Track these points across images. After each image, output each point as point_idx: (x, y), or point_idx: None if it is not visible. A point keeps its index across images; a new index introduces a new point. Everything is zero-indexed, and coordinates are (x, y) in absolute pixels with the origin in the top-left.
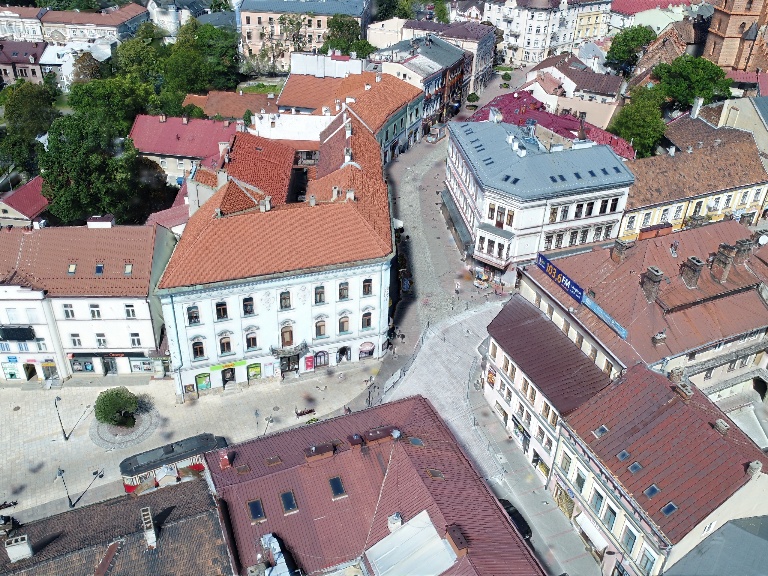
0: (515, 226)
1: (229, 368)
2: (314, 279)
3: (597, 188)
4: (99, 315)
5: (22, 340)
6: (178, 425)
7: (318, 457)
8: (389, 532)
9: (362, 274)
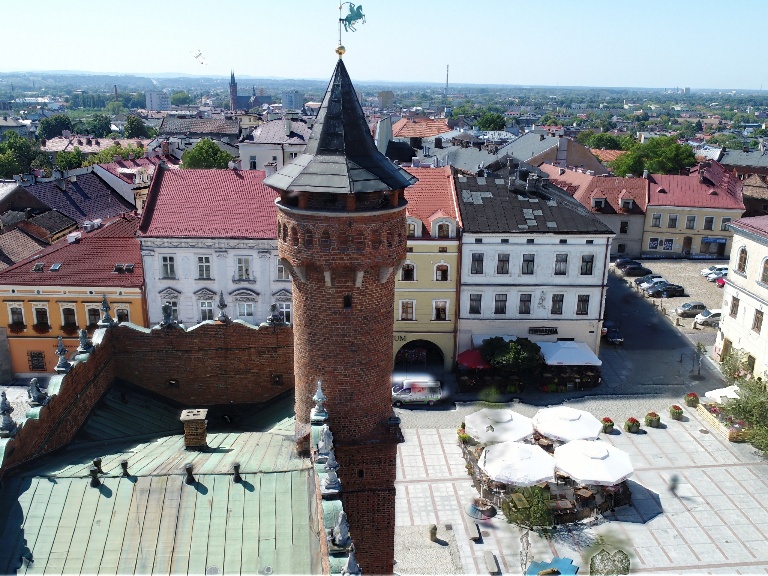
0: None
1: None
2: None
3: None
4: None
5: None
6: None
7: None
8: None
9: None
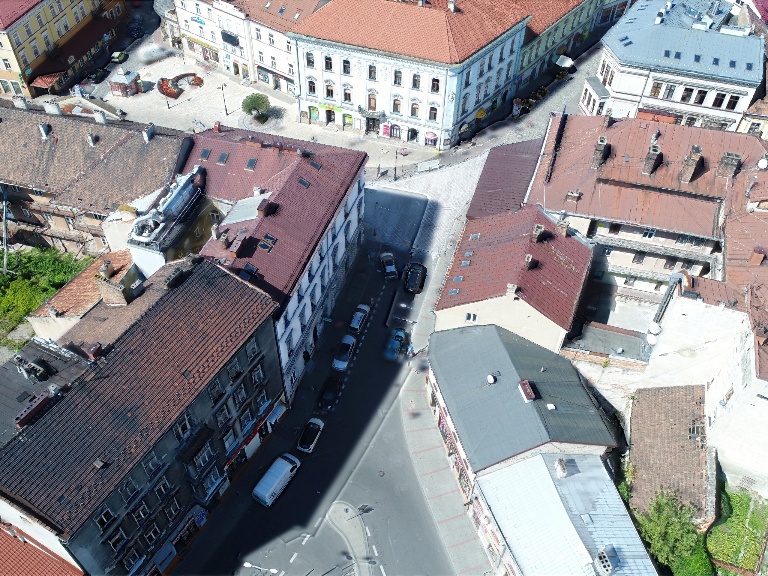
0: (612, 87)
1: (331, 110)
2: (394, 63)
3: (710, 77)
4: (274, 43)
5: (232, 44)
6: (286, 133)
7: (252, 144)
8: None
9: (431, 72)
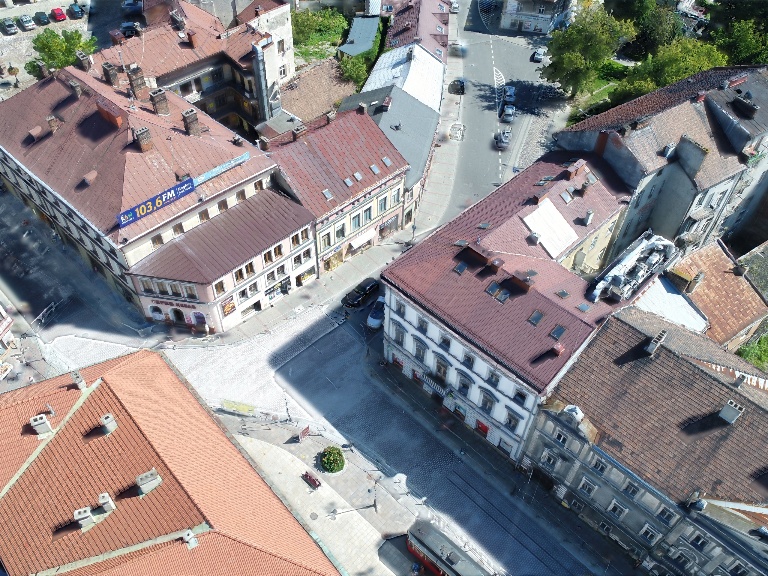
0: None
1: None
2: None
3: None
4: None
5: None
6: None
7: None
8: (539, 244)
9: None
